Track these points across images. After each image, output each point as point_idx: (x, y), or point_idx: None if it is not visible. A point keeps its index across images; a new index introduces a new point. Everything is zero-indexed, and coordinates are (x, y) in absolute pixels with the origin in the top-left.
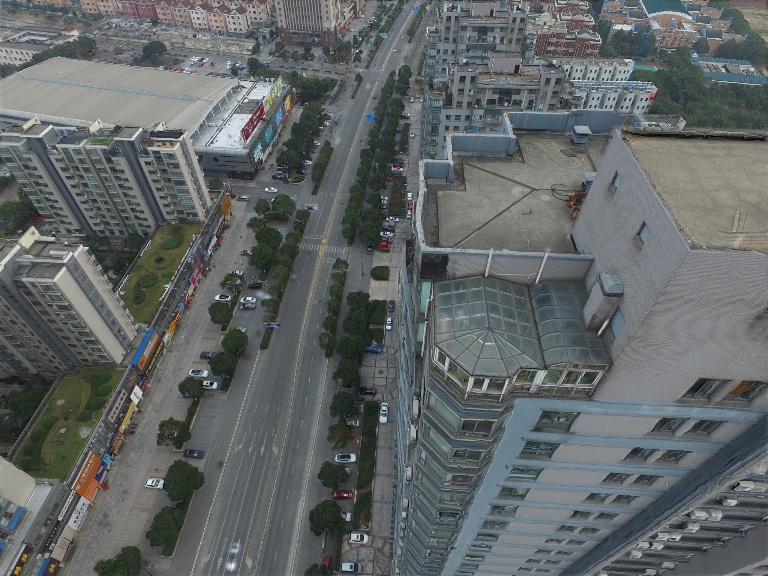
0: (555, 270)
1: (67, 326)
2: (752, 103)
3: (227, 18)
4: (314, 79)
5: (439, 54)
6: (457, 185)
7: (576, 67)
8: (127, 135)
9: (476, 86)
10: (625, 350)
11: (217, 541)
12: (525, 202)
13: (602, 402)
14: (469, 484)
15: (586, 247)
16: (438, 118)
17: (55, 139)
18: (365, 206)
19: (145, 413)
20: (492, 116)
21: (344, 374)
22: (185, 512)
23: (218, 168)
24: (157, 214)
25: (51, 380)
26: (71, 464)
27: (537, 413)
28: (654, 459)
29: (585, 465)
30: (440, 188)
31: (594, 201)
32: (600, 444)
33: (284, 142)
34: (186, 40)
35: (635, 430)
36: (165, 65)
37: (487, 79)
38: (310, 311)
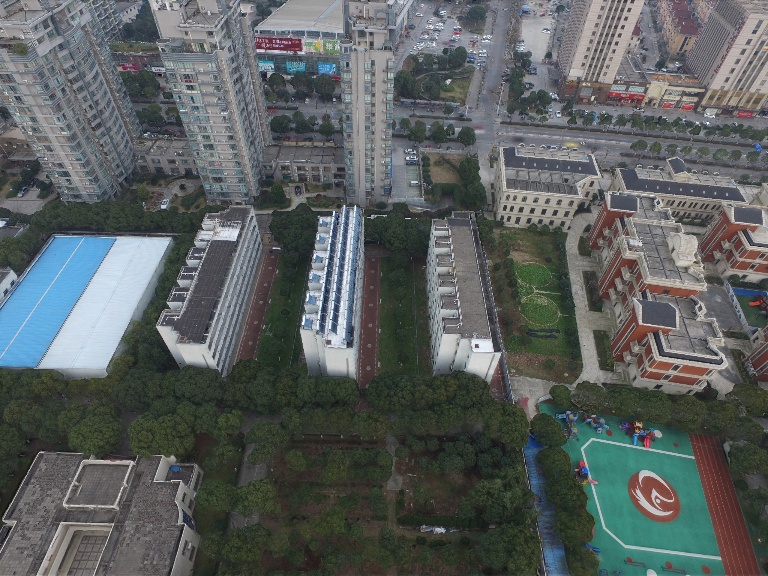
0: None
1: None
2: None
3: None
4: None
5: None
6: None
7: None
8: None
9: None
10: None
11: None
12: None
13: None
14: None
15: None
16: None
17: None
18: None
19: None
20: None
21: None
22: None
23: None
24: None
25: None
26: None
27: None
28: None
29: None
30: None
31: None
32: None
33: None
34: None
35: None
36: (466, 28)
37: None
38: None
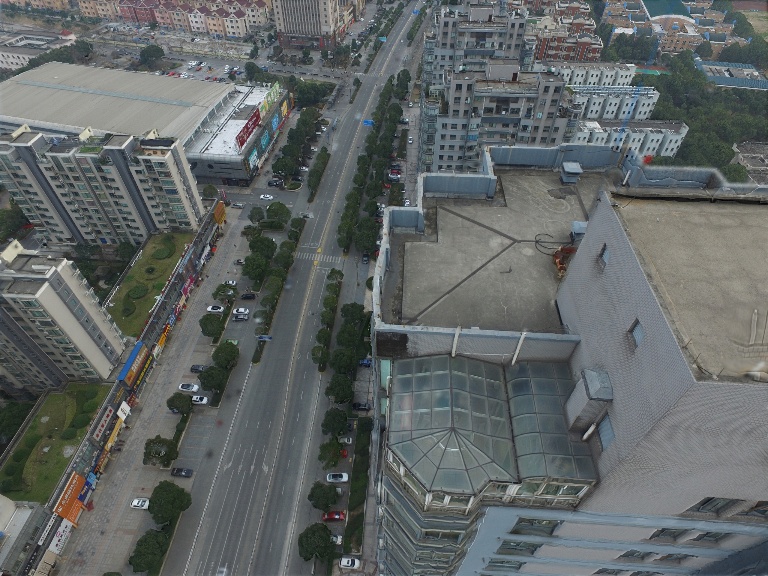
0: (534, 350)
1: (51, 342)
2: (756, 108)
3: (225, 22)
4: (312, 84)
5: (436, 60)
6: (428, 234)
7: (577, 72)
8: (117, 143)
9: (473, 94)
10: (614, 470)
11: (203, 565)
12: (504, 257)
13: (589, 513)
14: (441, 575)
15: (571, 323)
16: (434, 127)
17: (44, 147)
18: (361, 214)
19: (133, 429)
20: (489, 125)
21: (337, 390)
22: (171, 534)
23: (213, 175)
24: (149, 223)
25: (38, 394)
26: (53, 485)
27: (513, 519)
28: (652, 559)
29: (573, 562)
30: (409, 238)
31: (580, 270)
32: (589, 546)
33: (281, 148)
34: (184, 44)
35: (629, 537)
36: (162, 69)
37: (484, 87)
38: (304, 323)
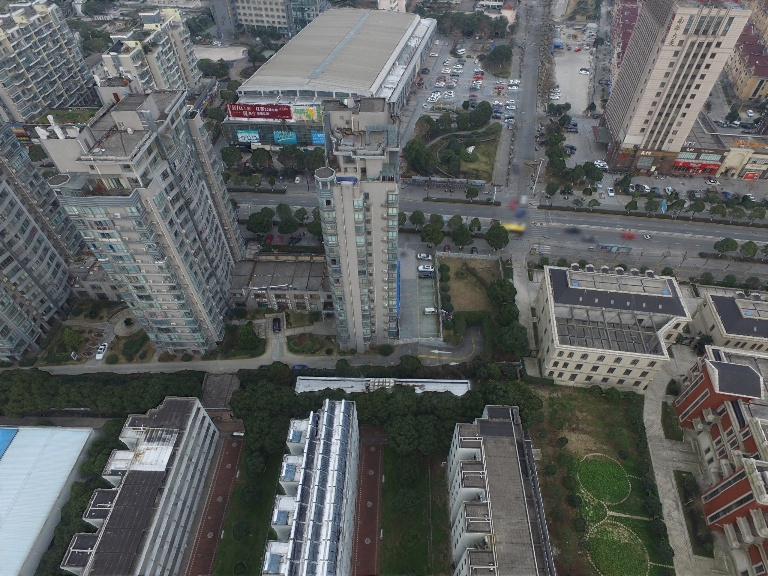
0: None
1: None
2: None
3: None
4: (424, 148)
5: None
6: None
7: None
8: (118, 34)
9: None
10: None
11: None
12: None
13: None
14: None
15: None
16: None
17: (150, 22)
18: None
19: None
20: None
21: None
22: None
23: None
24: None
25: None
26: None
27: None
28: None
29: None
30: None
31: None
32: None
33: None
34: None
35: None
36: (489, 71)
37: None
38: None
